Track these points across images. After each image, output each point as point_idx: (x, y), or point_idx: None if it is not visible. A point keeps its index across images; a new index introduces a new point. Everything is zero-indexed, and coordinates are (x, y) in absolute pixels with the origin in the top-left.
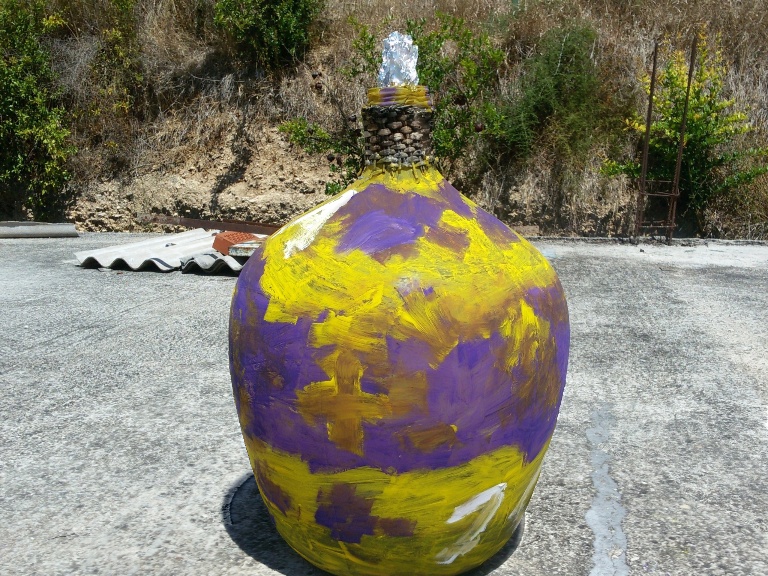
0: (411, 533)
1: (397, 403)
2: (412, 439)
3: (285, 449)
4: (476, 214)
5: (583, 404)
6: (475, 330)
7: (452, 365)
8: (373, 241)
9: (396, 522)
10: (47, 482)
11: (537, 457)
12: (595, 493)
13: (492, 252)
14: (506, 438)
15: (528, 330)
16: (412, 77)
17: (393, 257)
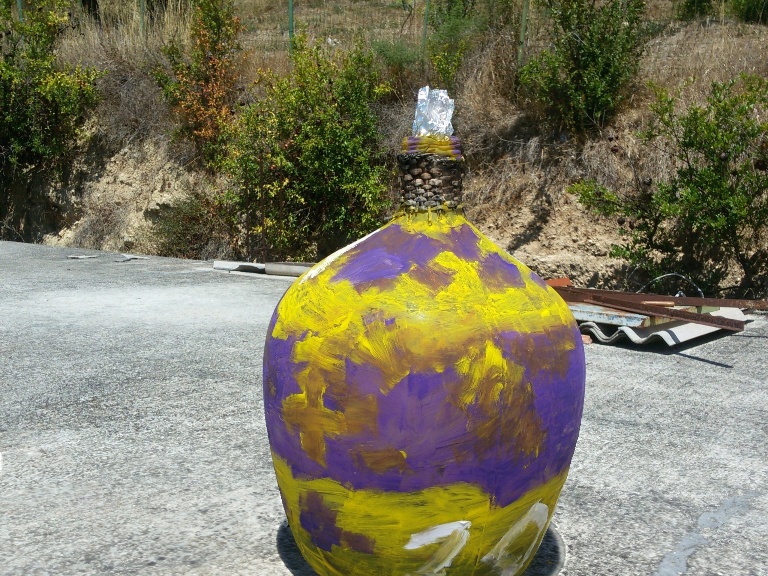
0: (371, 551)
1: (351, 422)
2: (365, 458)
3: (279, 453)
4: (485, 258)
5: (725, 488)
6: (428, 363)
7: (402, 393)
8: (362, 274)
9: (357, 537)
10: (179, 467)
11: (514, 504)
12: (653, 572)
13: (474, 293)
14: (463, 475)
15: (490, 371)
16: (444, 128)
17: (371, 289)
